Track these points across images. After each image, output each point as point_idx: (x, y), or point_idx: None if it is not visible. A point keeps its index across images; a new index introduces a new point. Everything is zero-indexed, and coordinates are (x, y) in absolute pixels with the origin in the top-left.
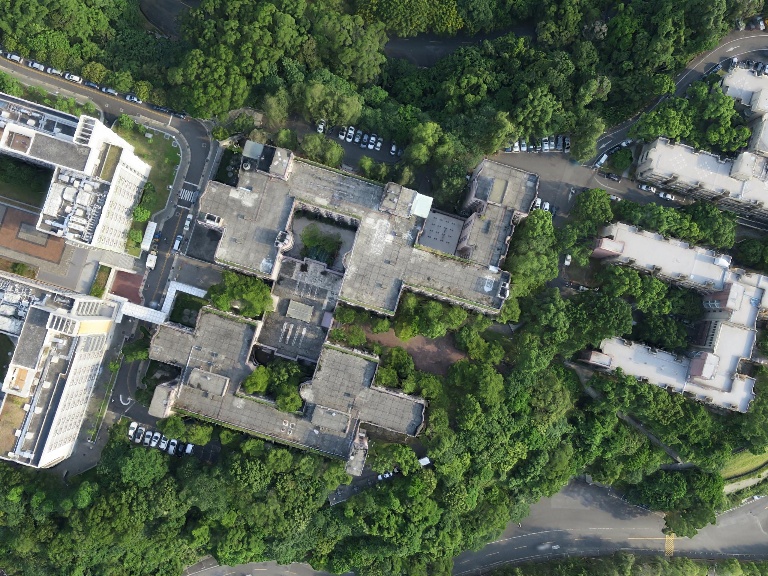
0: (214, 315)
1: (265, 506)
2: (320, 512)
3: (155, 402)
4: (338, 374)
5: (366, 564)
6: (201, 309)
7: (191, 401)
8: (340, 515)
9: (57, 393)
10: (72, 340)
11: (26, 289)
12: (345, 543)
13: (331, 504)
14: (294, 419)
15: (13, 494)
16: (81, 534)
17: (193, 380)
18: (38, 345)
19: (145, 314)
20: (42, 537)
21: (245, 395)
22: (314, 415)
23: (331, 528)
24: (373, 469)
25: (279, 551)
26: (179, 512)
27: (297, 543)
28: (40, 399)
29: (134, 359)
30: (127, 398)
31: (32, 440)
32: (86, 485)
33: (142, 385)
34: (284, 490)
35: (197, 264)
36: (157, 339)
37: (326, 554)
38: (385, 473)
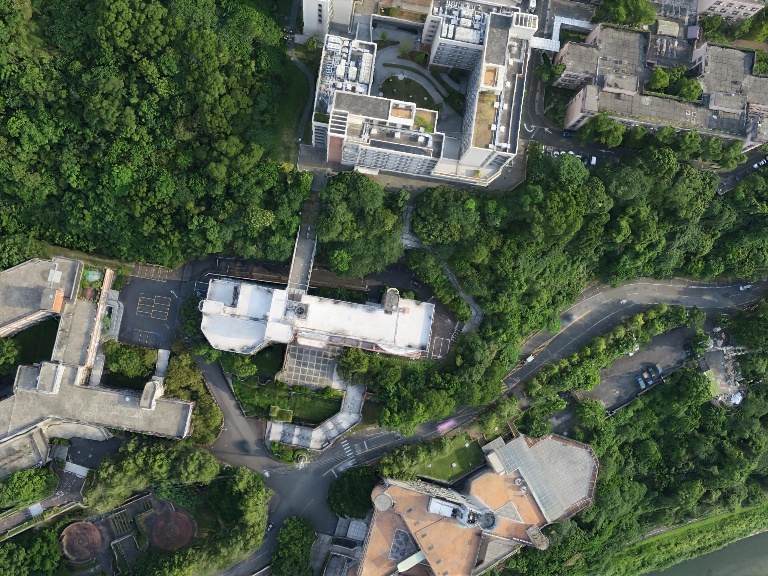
0: (611, 29)
1: (685, 185)
2: (714, 200)
3: (589, 98)
4: (723, 66)
5: (742, 257)
6: (601, 24)
7: (606, 104)
8: (730, 202)
9: (518, 90)
10: (521, 45)
11: (475, 6)
12: (720, 243)
13: (720, 194)
14: (694, 109)
15: (473, 201)
16: (539, 227)
17: (610, 81)
18: (503, 45)
19: (543, 44)
20: (494, 244)
21: (652, 92)
22: (716, 98)
23: (727, 212)
24: (764, 146)
25: (671, 252)
26: (610, 204)
27: (686, 243)
28: (504, 98)
29: (548, 77)
30: (531, 126)
31: (504, 134)
32: (533, 186)
33: (541, 113)
34: (688, 178)
35: (568, 4)
36: (568, 55)
37: (702, 258)
38: (760, 161)
